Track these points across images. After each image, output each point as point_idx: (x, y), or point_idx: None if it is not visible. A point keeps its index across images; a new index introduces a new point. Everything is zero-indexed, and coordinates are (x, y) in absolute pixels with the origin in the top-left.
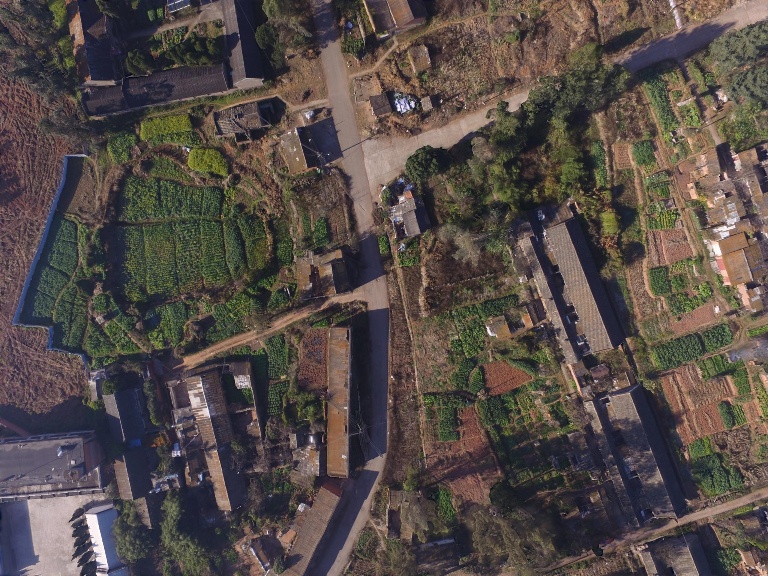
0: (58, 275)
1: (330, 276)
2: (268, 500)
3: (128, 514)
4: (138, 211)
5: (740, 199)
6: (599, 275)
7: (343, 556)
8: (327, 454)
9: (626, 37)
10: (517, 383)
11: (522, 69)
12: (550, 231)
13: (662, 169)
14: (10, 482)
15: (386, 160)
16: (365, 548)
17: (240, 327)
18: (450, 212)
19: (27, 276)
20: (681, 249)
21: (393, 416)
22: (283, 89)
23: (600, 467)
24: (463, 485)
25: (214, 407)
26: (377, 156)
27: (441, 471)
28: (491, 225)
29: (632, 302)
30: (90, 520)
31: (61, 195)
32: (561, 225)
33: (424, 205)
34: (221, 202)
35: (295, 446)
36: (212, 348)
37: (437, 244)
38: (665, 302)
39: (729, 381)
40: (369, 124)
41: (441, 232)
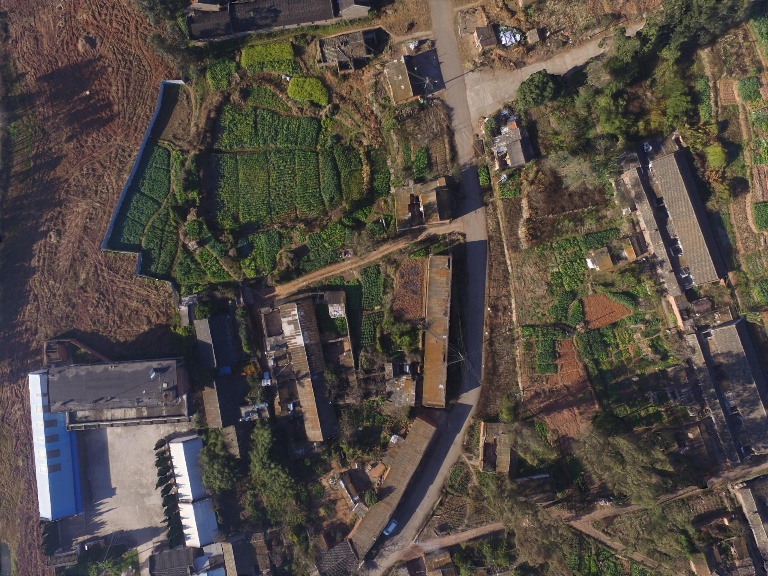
0: (149, 201)
1: (434, 203)
2: (358, 433)
3: (215, 443)
4: (234, 139)
5: None
6: (705, 207)
7: (433, 491)
8: (423, 384)
9: None
10: (616, 317)
11: (628, 5)
12: (657, 162)
13: (767, 105)
14: (99, 404)
15: (488, 92)
16: (457, 483)
17: (334, 257)
18: (553, 144)
19: (118, 201)
20: None
21: (489, 349)
22: (387, 20)
23: None
24: (559, 419)
25: (308, 335)
26: (479, 88)
27: (537, 405)
28: (596, 157)
29: (735, 237)
30: (174, 449)
31: (155, 121)
32: (669, 156)
33: (528, 136)
34: (317, 133)
35: (391, 375)
36: (305, 277)
37: (539, 176)
38: None
39: None
40: (472, 57)
41: (548, 160)
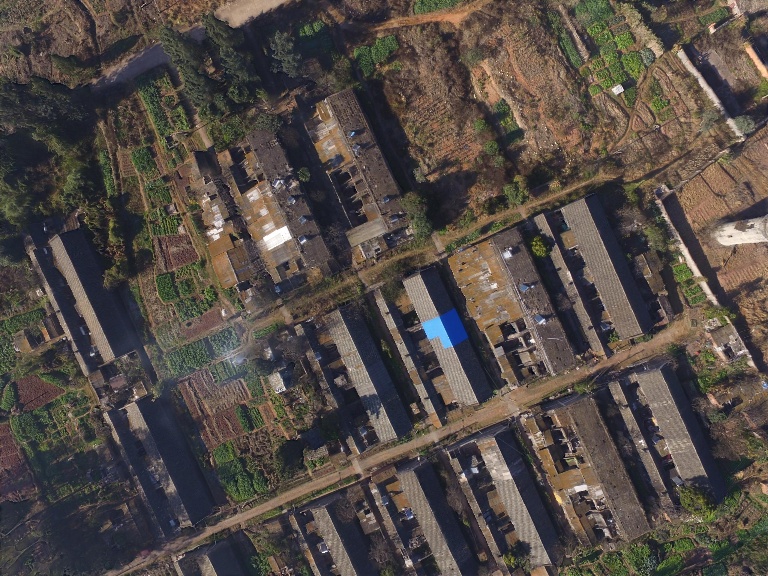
0: None
1: None
2: None
3: None
4: None
5: (222, 201)
6: (102, 285)
7: None
8: None
9: (119, 45)
10: (50, 397)
11: None
12: (52, 243)
13: (163, 175)
14: None
15: None
16: None
17: None
18: None
19: None
20: (186, 254)
21: None
22: None
23: None
24: None
25: None
26: None
27: None
28: None
29: (146, 310)
30: None
31: None
32: (57, 237)
33: None
34: None
35: None
36: None
37: None
38: (175, 308)
39: (244, 384)
40: None
41: None
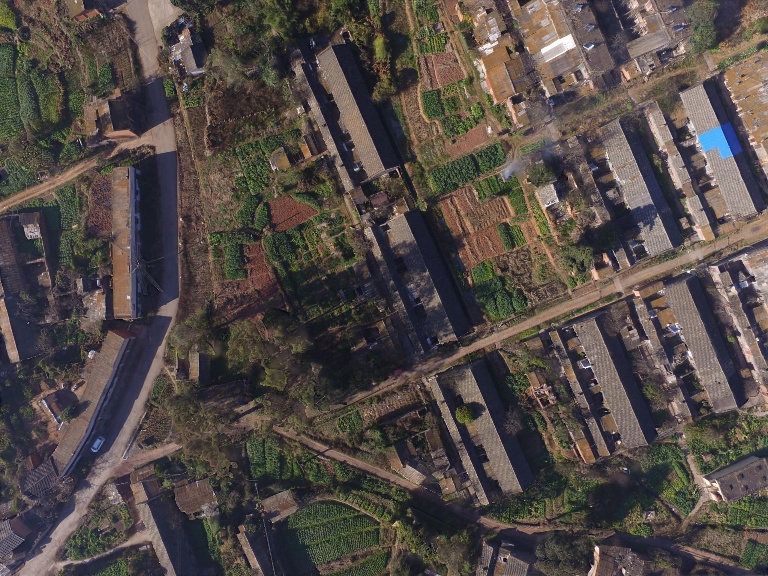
0: None
1: (107, 114)
2: (62, 353)
3: None
4: None
5: (500, 14)
6: (370, 99)
7: (139, 406)
8: (113, 297)
9: None
10: (303, 218)
11: None
12: (320, 57)
13: None
14: None
15: (169, 3)
16: (160, 396)
17: (32, 179)
18: (229, 49)
19: None
20: (452, 72)
21: (184, 259)
22: None
23: (387, 298)
24: None
25: (2, 257)
26: (160, 0)
27: (231, 311)
28: None
29: (408, 128)
30: None
31: None
32: (329, 49)
33: (202, 42)
34: (14, 58)
35: (82, 291)
36: (5, 202)
37: (218, 82)
38: (439, 125)
39: (506, 202)
40: None
41: None
